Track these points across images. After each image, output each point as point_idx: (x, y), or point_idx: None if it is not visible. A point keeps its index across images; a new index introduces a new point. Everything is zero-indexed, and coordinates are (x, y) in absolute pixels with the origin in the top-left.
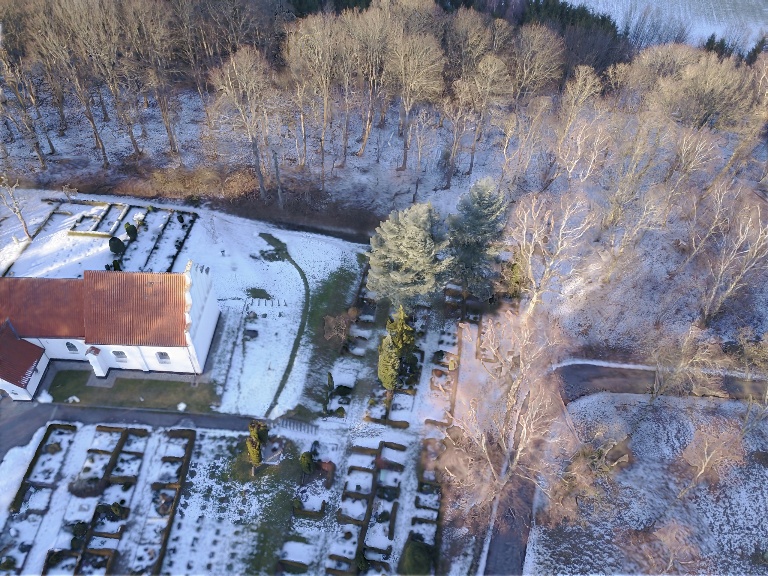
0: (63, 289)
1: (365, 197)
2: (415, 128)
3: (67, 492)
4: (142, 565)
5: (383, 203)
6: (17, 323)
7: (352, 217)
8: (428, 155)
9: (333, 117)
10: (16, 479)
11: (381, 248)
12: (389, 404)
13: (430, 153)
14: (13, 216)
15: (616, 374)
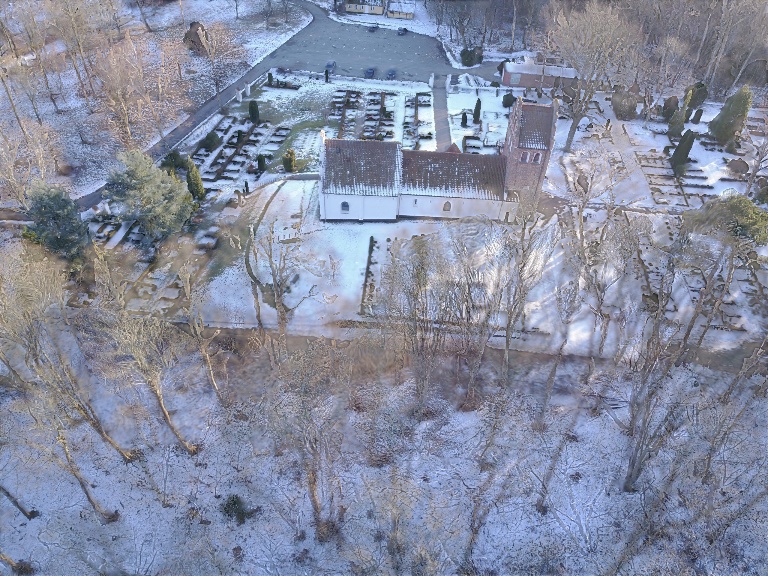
0: None
1: None
2: None
3: None
4: None
5: None
6: None
7: None
8: None
9: None
10: None
11: (168, 205)
12: None
13: None
14: None
15: (18, 217)
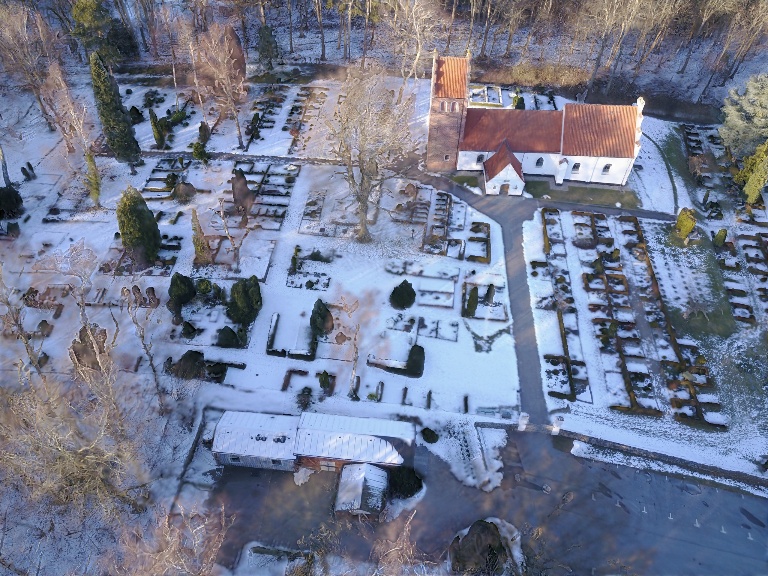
0: (547, 117)
1: (666, 89)
2: (729, 29)
3: (573, 246)
4: (644, 285)
5: (682, 93)
6: (512, 142)
7: (664, 101)
8: (736, 50)
9: (635, 29)
10: (538, 237)
11: (733, 107)
12: (751, 213)
13: (738, 48)
14: (418, 94)
15: None
